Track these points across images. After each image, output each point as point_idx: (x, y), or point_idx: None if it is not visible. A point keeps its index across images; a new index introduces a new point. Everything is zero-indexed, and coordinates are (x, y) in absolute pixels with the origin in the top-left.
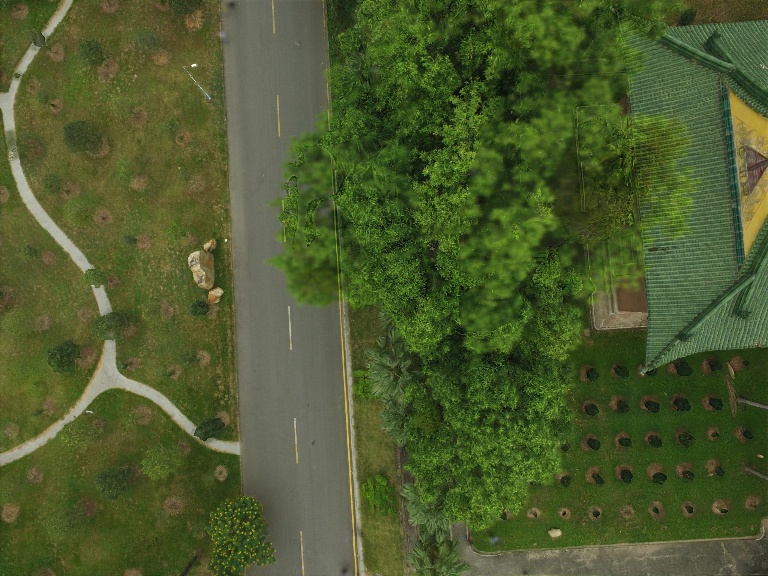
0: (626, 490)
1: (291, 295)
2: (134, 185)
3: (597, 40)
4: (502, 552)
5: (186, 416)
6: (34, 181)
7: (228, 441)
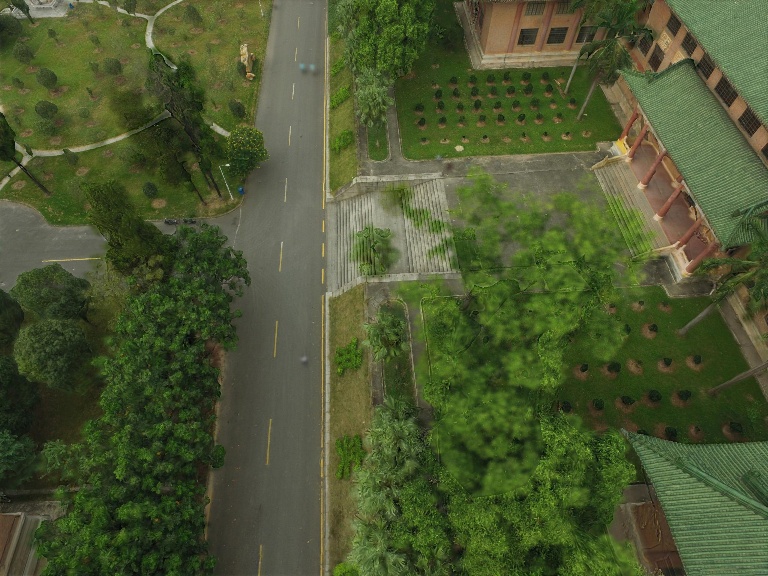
0: (504, 130)
1: (296, 79)
2: (213, 42)
3: None
4: None
5: (219, 126)
6: (157, 41)
7: None
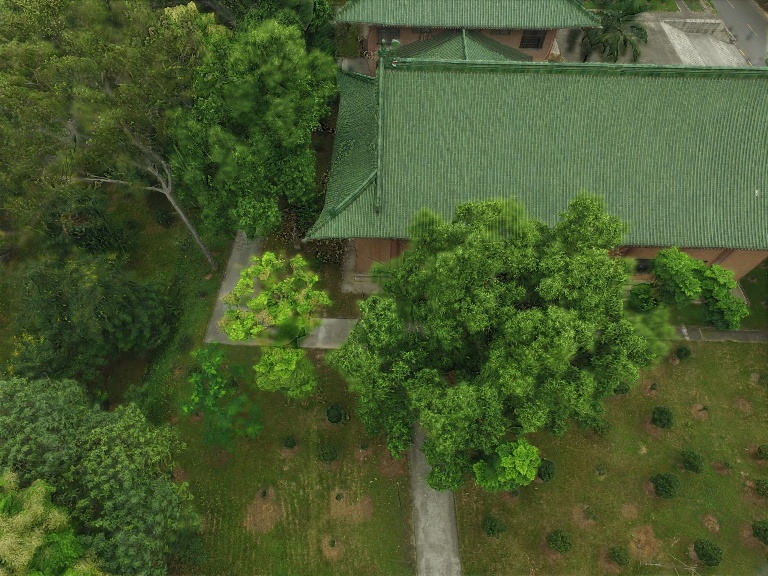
0: None
1: None
2: None
3: (749, 357)
4: None
5: None
6: None
7: None
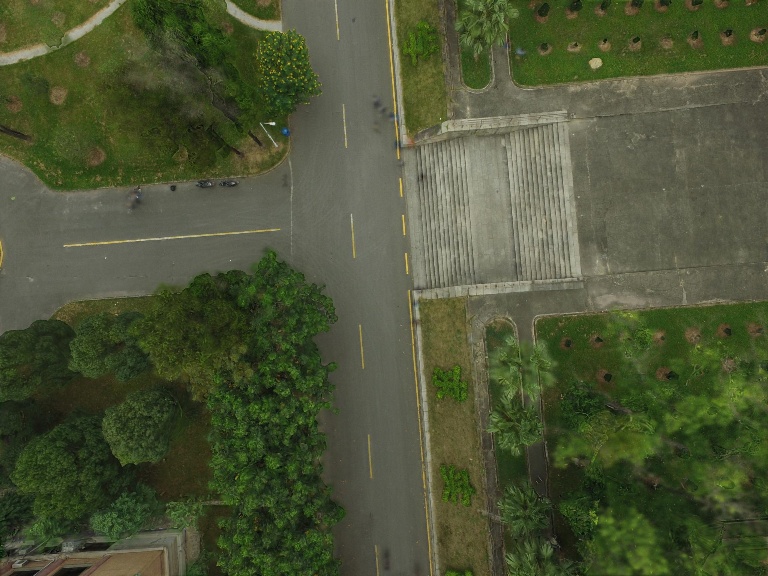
0: (665, 21)
1: None
2: None
3: None
4: (543, 87)
5: None
6: None
7: (270, 20)
